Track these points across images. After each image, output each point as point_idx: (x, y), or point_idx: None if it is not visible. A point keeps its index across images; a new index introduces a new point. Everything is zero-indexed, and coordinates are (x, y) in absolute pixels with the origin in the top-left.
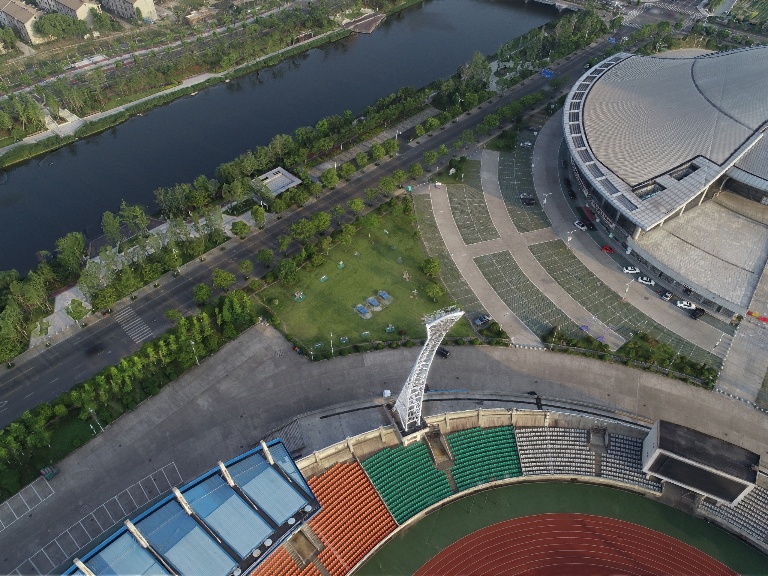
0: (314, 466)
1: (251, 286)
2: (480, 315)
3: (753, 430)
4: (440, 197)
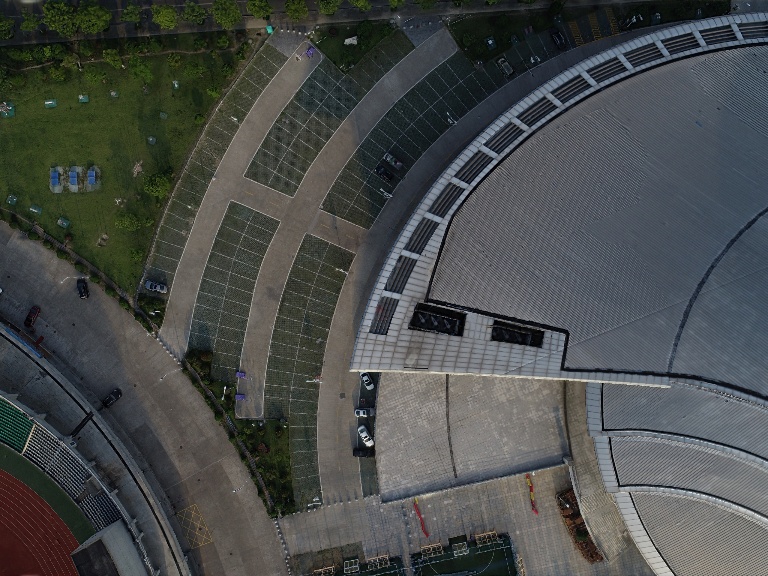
0: None
1: None
2: (162, 278)
3: (257, 570)
4: (294, 74)
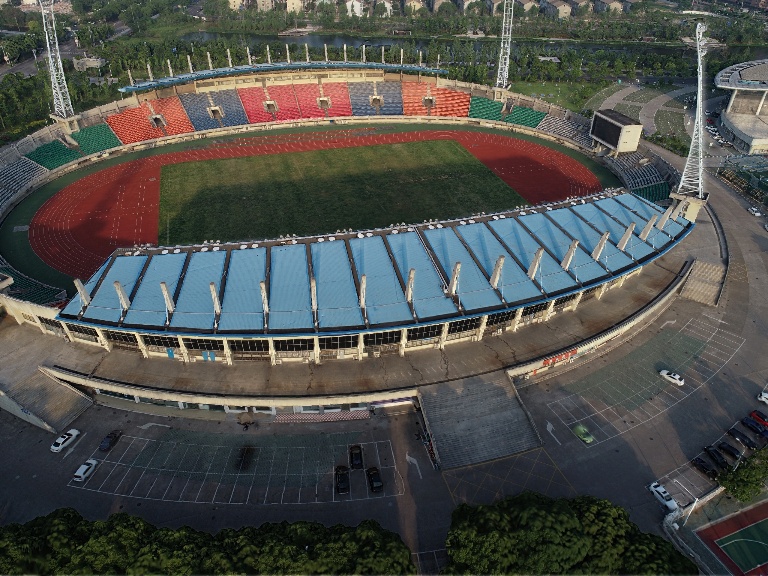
0: (453, 88)
1: (493, 75)
2: None
3: None
4: (634, 88)
